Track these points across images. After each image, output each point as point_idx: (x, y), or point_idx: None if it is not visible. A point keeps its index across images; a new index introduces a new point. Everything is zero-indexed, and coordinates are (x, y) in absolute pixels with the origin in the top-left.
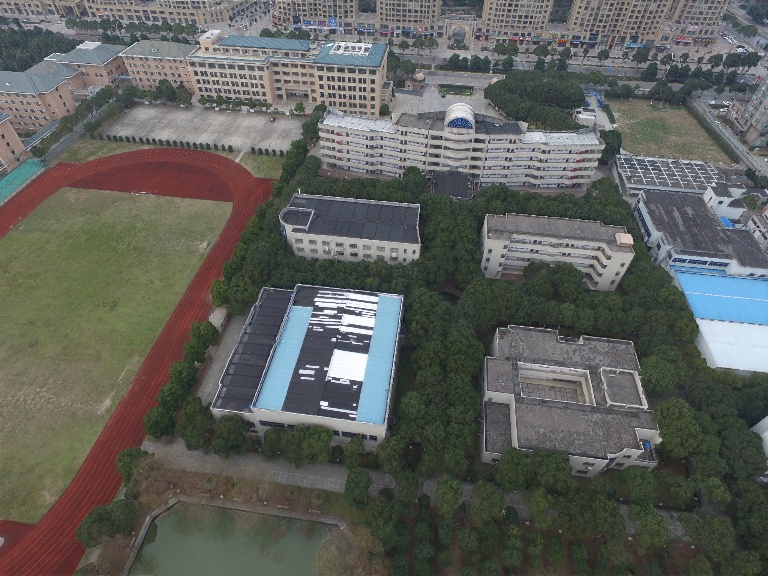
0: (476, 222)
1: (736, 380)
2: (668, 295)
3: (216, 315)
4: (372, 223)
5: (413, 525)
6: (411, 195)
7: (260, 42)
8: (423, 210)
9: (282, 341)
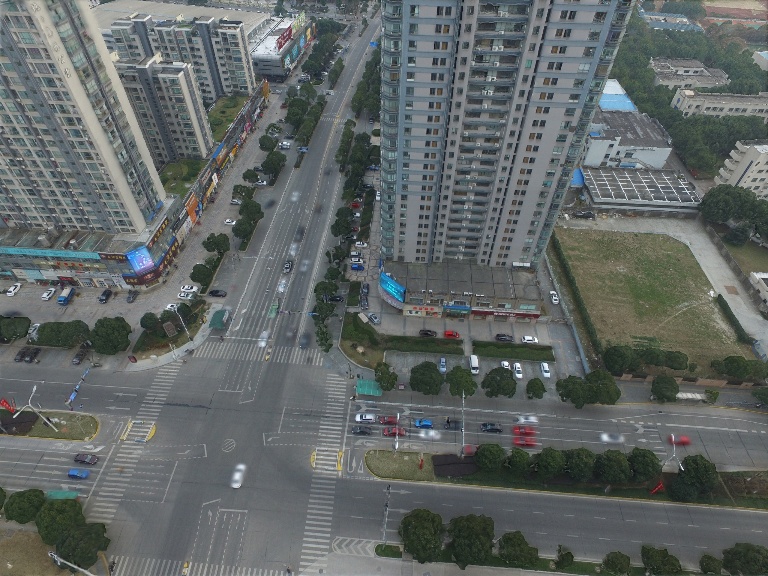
0: None
1: None
2: None
3: None
4: None
5: None
6: None
7: None
8: None
9: None
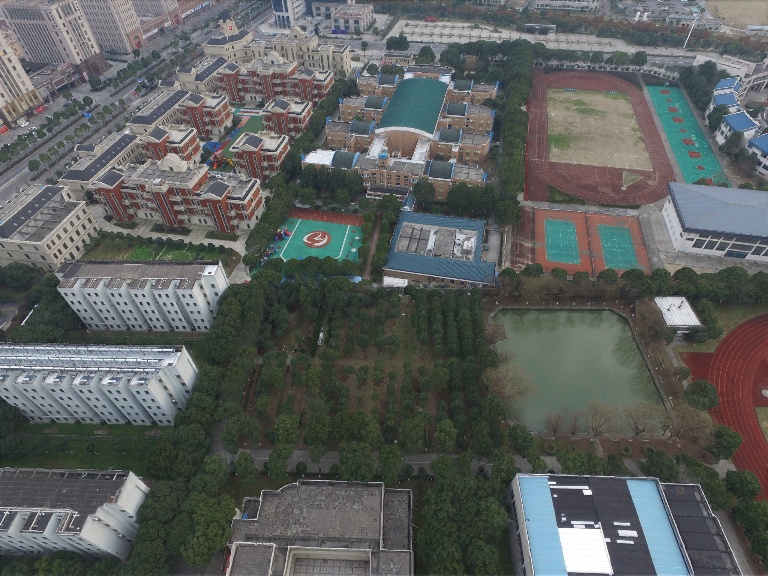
0: None
1: None
2: None
3: None
4: None
5: (468, 422)
6: None
7: None
8: None
9: None
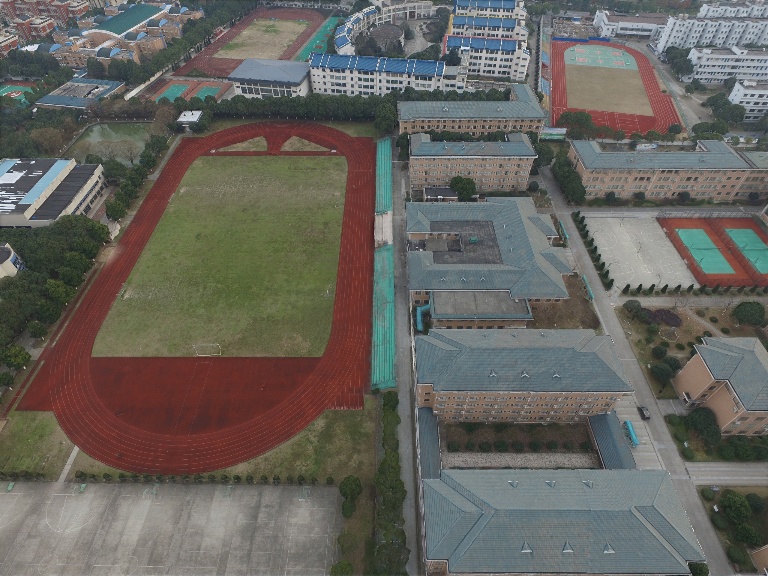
0: None
1: None
2: None
3: (111, 230)
4: None
5: None
6: None
7: None
8: None
9: None
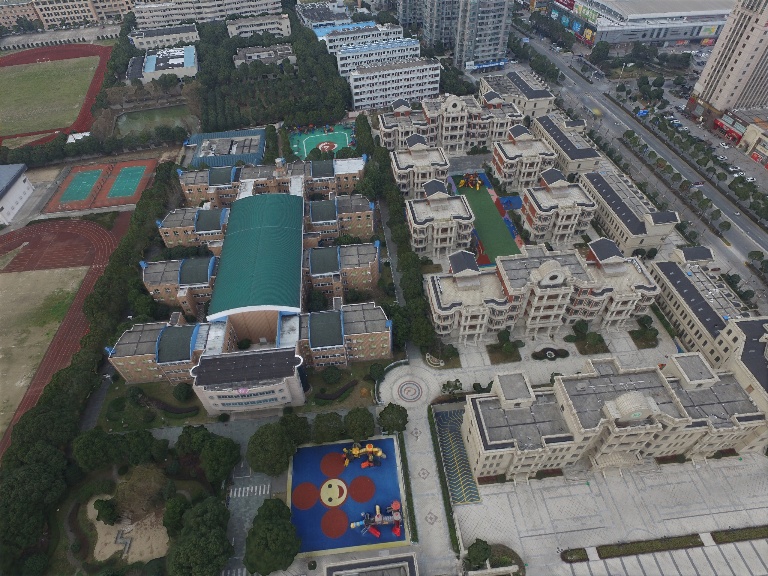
0: (225, 29)
1: (324, 41)
2: (306, 32)
3: None
4: (174, 31)
5: None
6: None
7: None
8: (200, 31)
9: (147, 62)
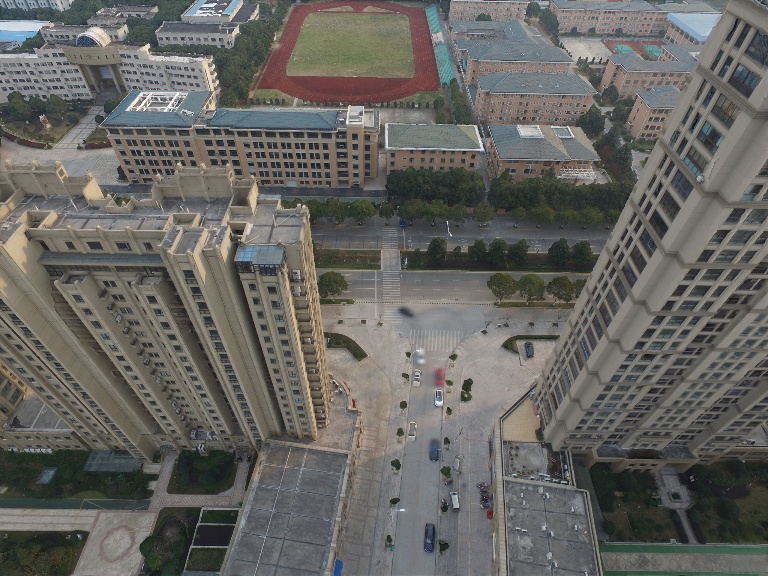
0: None
1: None
2: None
3: None
4: None
5: None
6: (157, 47)
7: (282, 110)
8: None
9: None
